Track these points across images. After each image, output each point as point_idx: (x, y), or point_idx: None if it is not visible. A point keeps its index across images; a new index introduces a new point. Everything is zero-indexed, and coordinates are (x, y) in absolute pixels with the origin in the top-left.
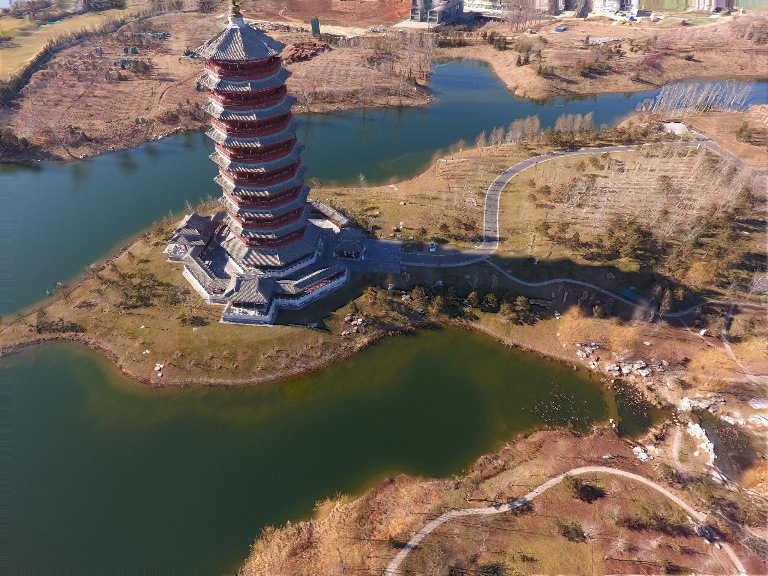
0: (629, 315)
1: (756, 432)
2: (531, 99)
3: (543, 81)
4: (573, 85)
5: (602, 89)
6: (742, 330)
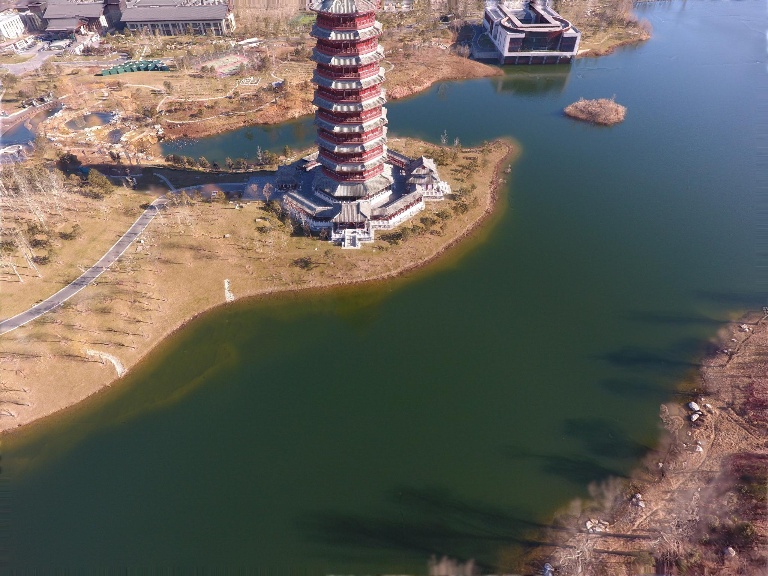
0: None
1: (96, 139)
2: None
3: None
4: None
5: None
6: (36, 162)
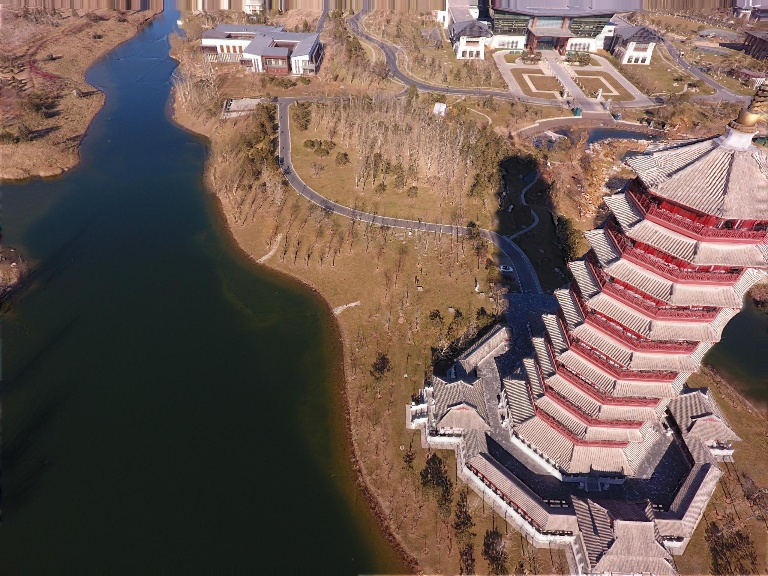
0: (548, 185)
1: (611, 174)
2: (74, 168)
3: (38, 145)
4: (62, 131)
5: (84, 119)
6: None
